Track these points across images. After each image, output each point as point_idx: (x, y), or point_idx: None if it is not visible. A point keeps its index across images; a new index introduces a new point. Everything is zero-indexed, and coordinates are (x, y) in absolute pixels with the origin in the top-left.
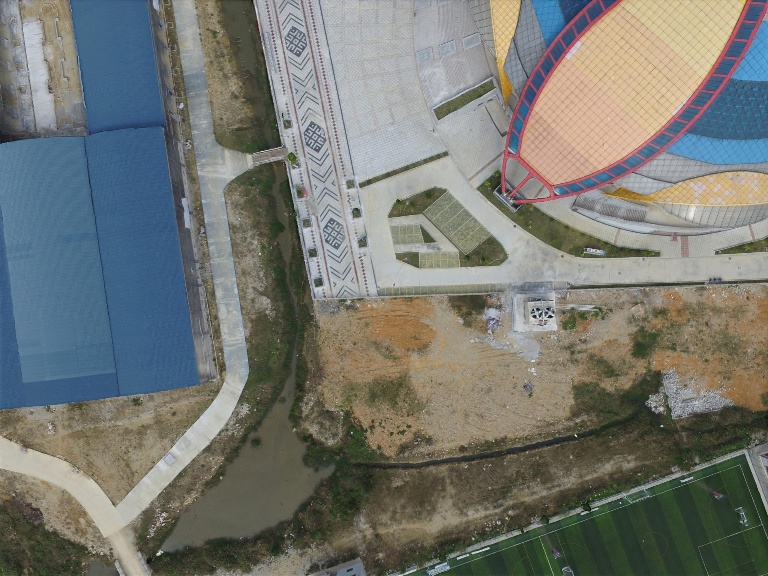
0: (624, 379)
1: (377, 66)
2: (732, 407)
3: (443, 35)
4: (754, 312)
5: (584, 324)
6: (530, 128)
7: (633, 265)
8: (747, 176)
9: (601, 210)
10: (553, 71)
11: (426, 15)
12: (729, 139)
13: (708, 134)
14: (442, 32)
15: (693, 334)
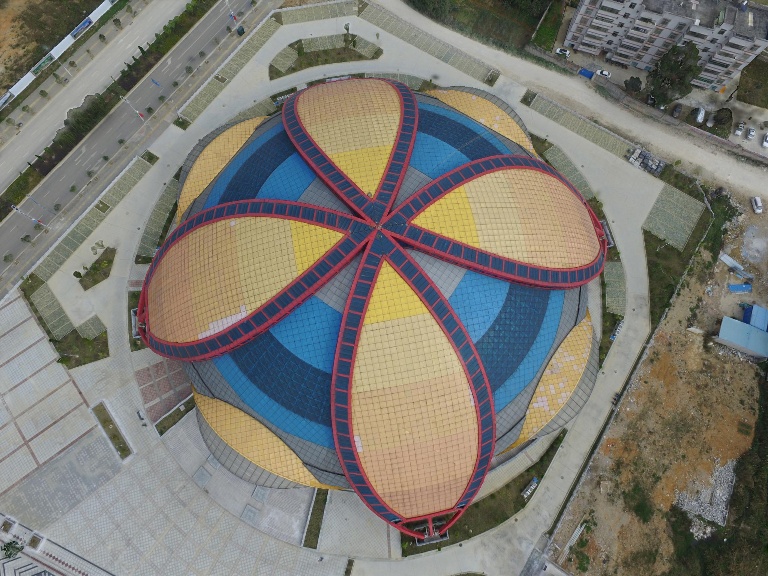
0: (664, 547)
1: (223, 567)
2: (738, 464)
3: (246, 486)
4: (660, 385)
5: (591, 547)
6: (391, 503)
7: (562, 460)
8: (557, 358)
9: (497, 458)
10: (361, 466)
11: (216, 485)
12: (520, 363)
13: (506, 378)
14: (242, 485)
15: (653, 451)
